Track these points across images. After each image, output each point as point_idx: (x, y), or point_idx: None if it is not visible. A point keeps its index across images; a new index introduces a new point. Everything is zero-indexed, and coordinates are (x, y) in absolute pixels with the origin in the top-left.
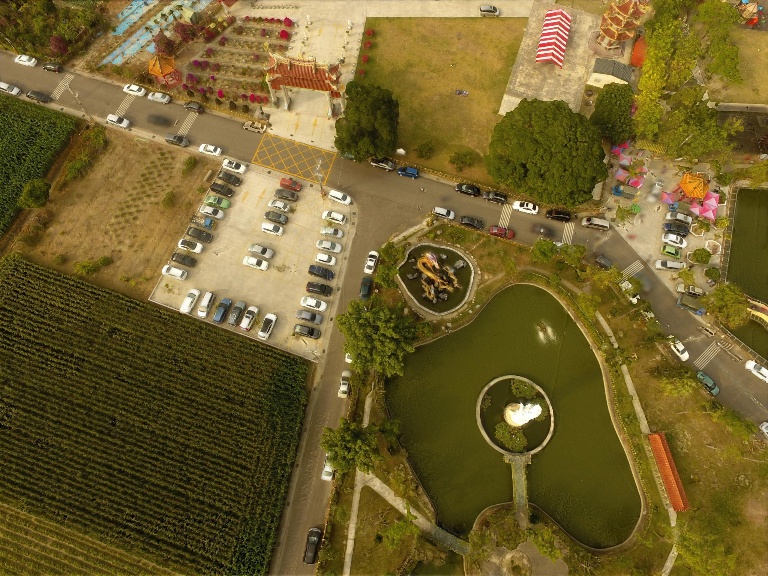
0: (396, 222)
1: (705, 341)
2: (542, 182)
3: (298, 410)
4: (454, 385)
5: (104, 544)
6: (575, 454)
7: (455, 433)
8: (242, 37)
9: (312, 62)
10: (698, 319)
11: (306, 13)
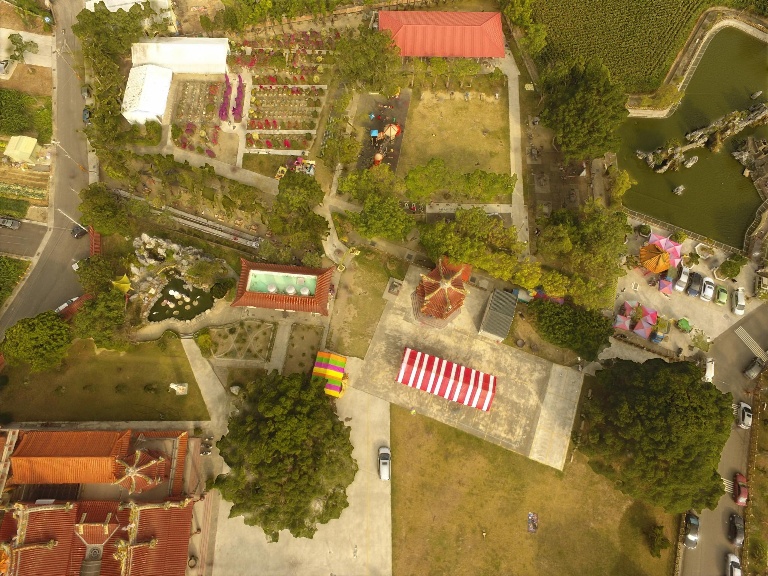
0: None
1: None
2: None
3: None
4: None
5: None
6: None
7: None
8: None
9: None
10: None
11: None
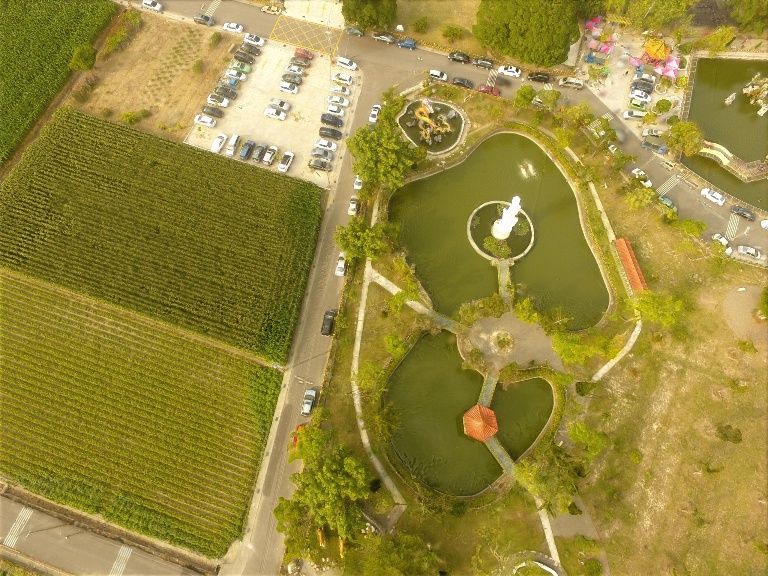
0: None
1: (666, 174)
2: (522, 40)
3: (314, 221)
4: (448, 211)
5: (153, 323)
6: (552, 261)
7: (449, 245)
8: None
9: None
10: (660, 157)
11: None
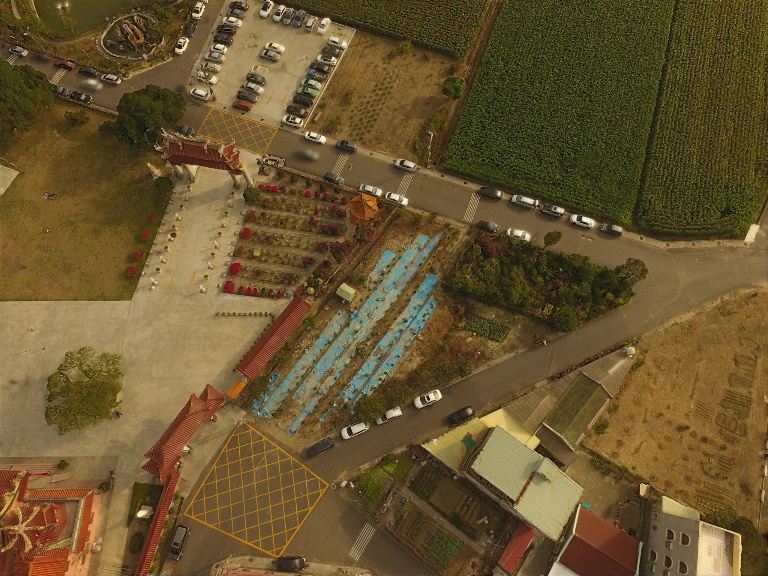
0: (155, 76)
1: None
2: (4, 62)
3: None
4: None
5: None
6: None
7: None
8: (287, 270)
9: (182, 139)
10: None
11: (207, 306)
